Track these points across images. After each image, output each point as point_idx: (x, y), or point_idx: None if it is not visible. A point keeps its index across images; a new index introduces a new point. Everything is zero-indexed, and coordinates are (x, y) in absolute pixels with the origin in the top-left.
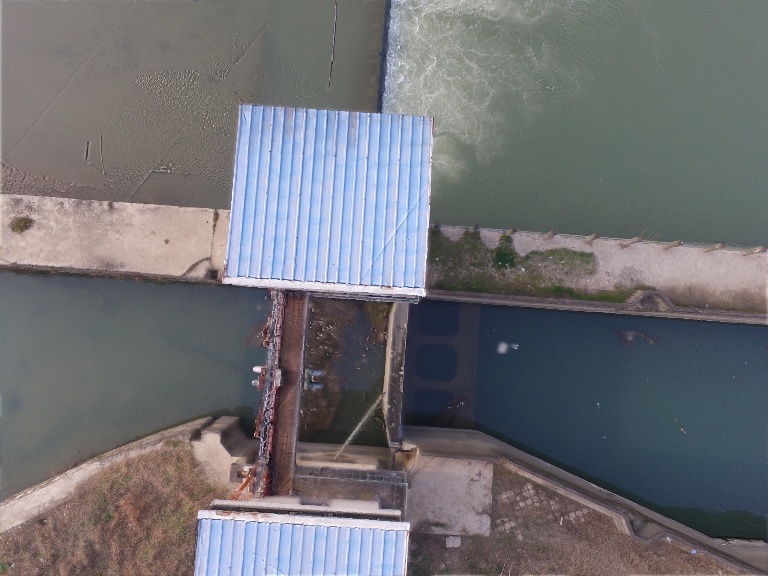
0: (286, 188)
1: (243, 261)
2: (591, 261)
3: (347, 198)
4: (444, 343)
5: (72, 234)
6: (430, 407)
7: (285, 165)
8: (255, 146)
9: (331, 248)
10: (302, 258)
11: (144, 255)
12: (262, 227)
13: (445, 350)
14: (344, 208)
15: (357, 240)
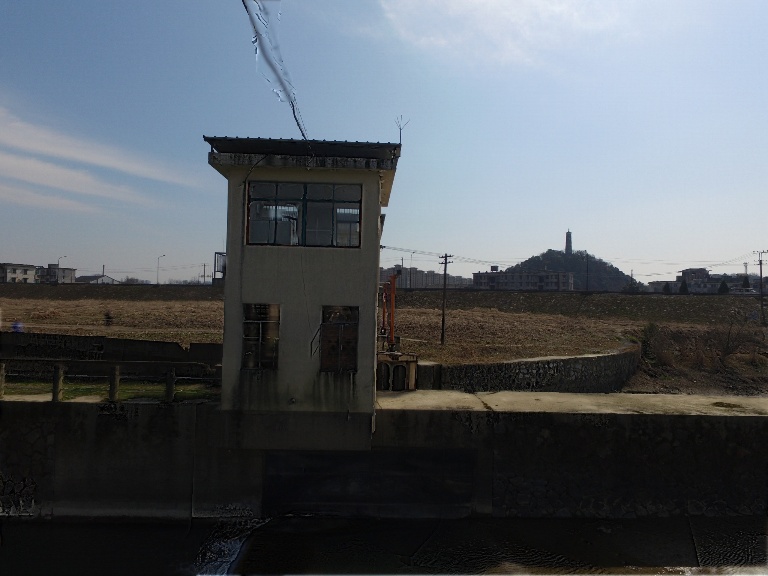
0: None
1: None
2: None
3: None
4: None
5: None
6: None
7: None
8: None
9: None
10: None
11: None
12: None
13: None
14: None
15: None
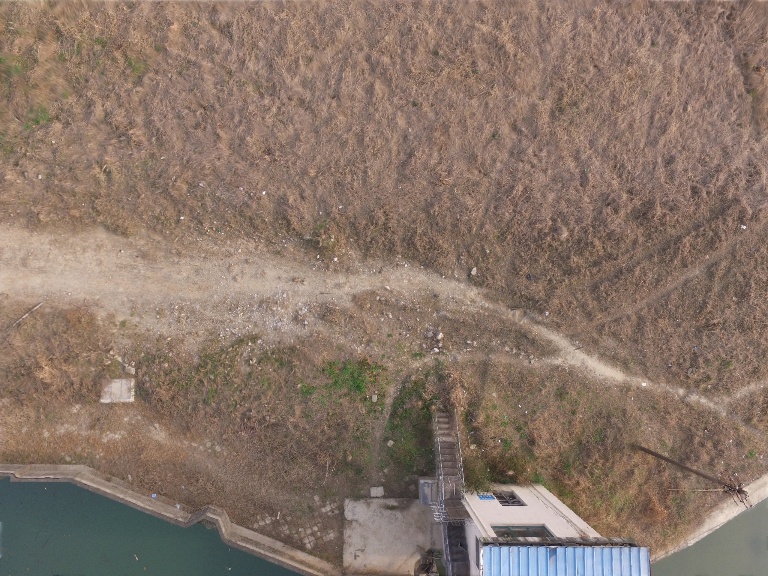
0: None
1: None
2: None
3: None
4: None
5: None
6: None
7: None
8: None
9: None
10: None
11: None
12: None
13: None
14: None
15: None
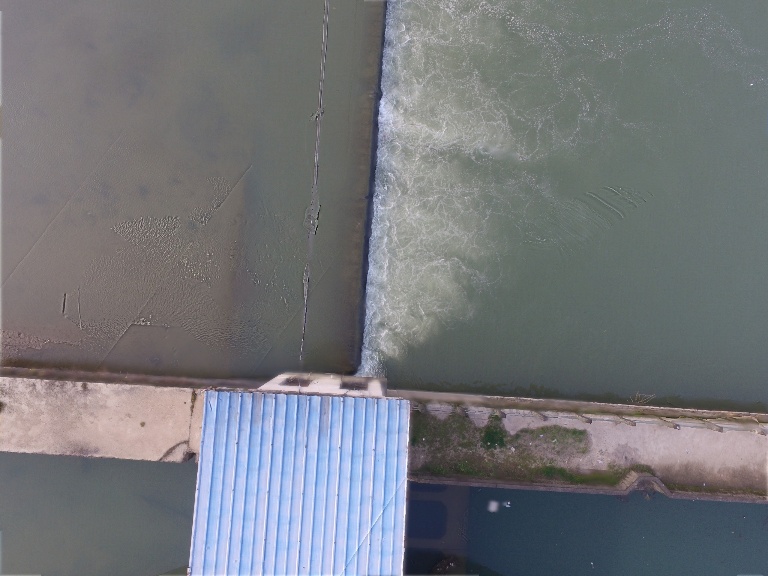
0: (254, 483)
1: (208, 567)
2: (584, 439)
3: (319, 493)
4: (433, 499)
5: (44, 418)
6: (419, 567)
7: (253, 457)
8: (221, 437)
9: (302, 550)
10: (271, 562)
11: (119, 439)
12: (228, 528)
13: (434, 506)
14: (316, 504)
15: (329, 540)
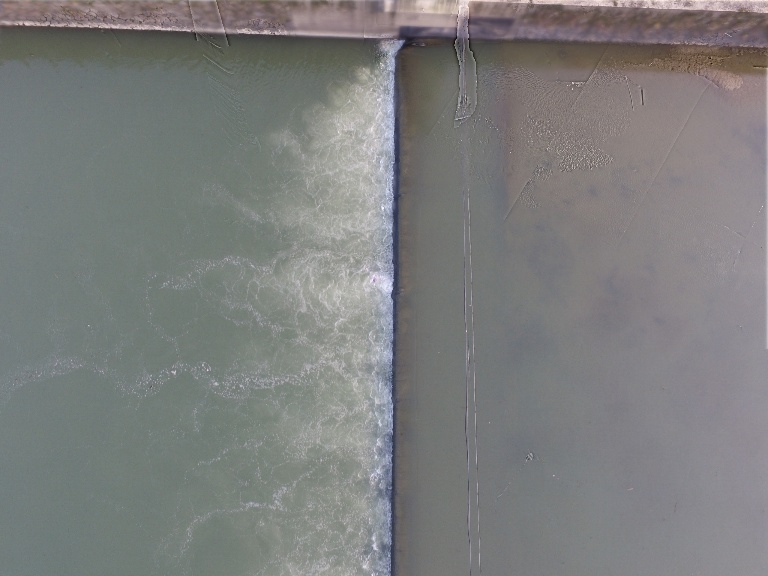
0: None
1: None
2: None
3: None
4: None
5: None
6: None
7: None
8: None
9: None
10: None
11: None
12: None
13: None
14: None
15: None
